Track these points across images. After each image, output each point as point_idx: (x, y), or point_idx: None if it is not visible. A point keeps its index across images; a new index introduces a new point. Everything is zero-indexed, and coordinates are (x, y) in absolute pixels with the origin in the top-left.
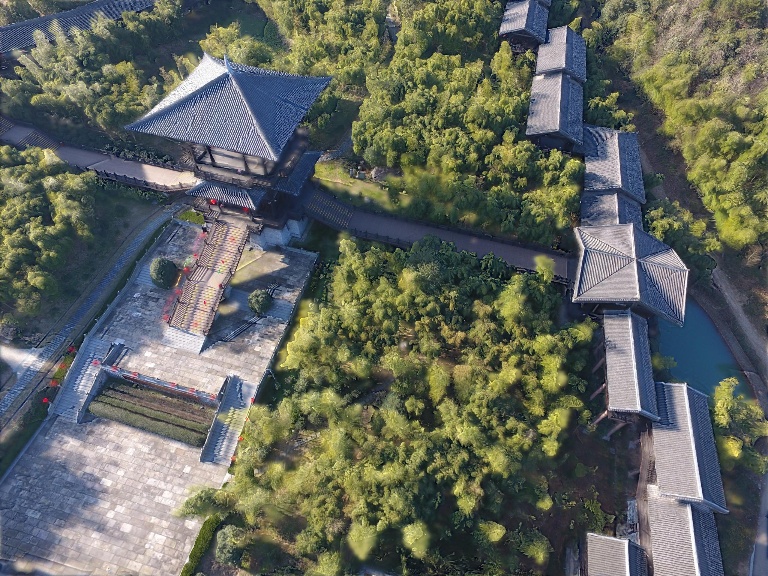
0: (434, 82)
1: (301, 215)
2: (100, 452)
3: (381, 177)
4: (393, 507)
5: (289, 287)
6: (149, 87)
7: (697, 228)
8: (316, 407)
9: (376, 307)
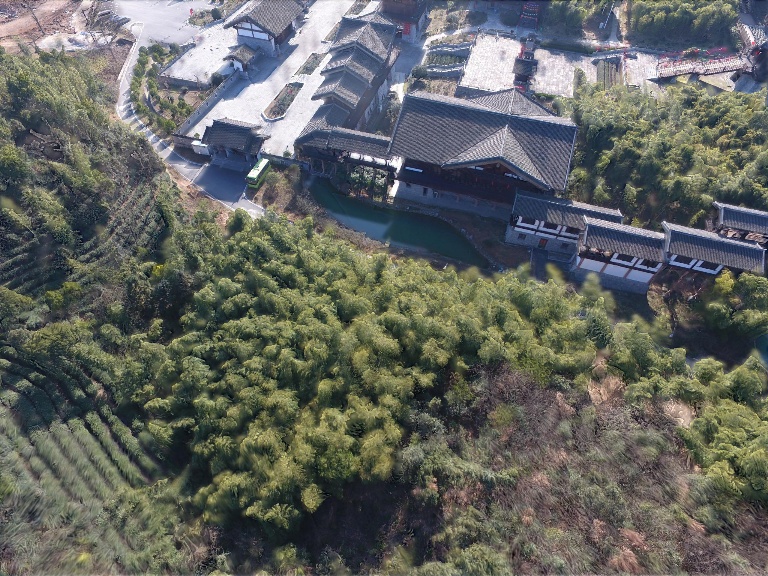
0: None
1: None
2: (582, 69)
3: None
4: None
5: None
6: None
7: None
8: None
9: None
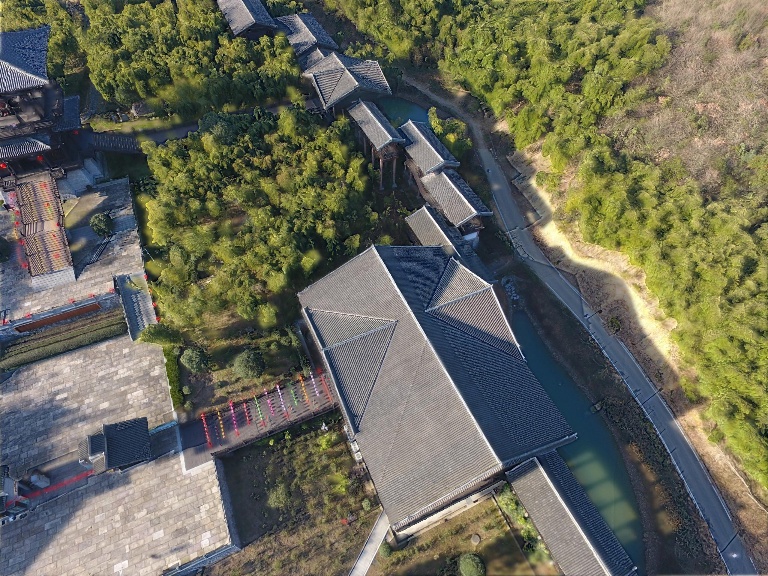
0: (139, 25)
1: (93, 152)
2: (38, 386)
3: (142, 111)
4: (286, 256)
5: (120, 207)
6: None
7: (377, 51)
8: (198, 250)
9: (198, 168)
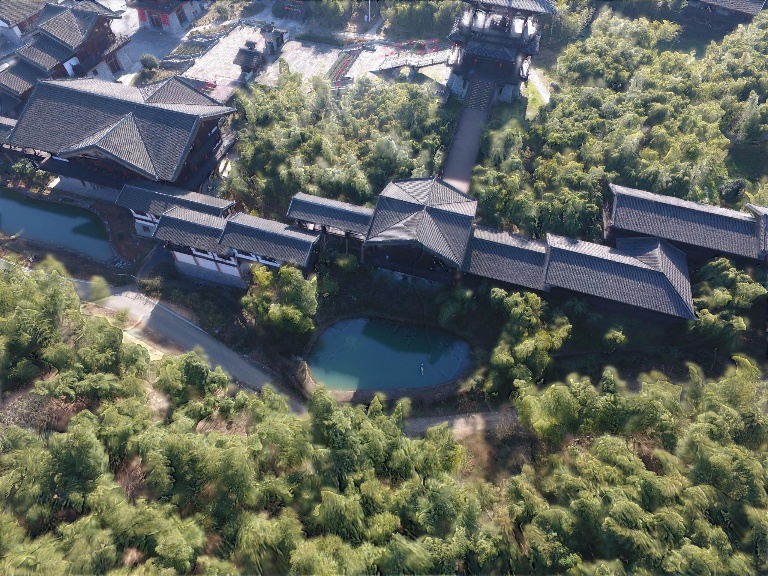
0: (661, 123)
1: (467, 78)
2: (323, 62)
3: None
4: None
5: None
6: (564, 5)
7: None
8: None
9: None
